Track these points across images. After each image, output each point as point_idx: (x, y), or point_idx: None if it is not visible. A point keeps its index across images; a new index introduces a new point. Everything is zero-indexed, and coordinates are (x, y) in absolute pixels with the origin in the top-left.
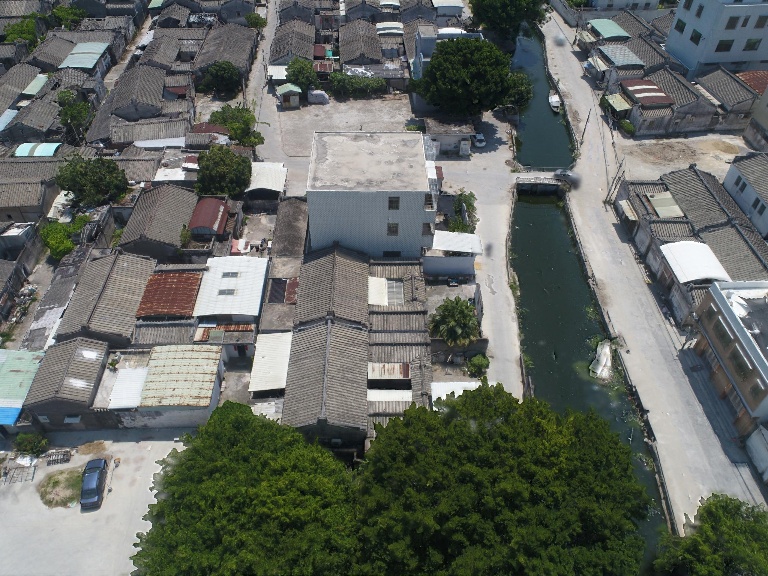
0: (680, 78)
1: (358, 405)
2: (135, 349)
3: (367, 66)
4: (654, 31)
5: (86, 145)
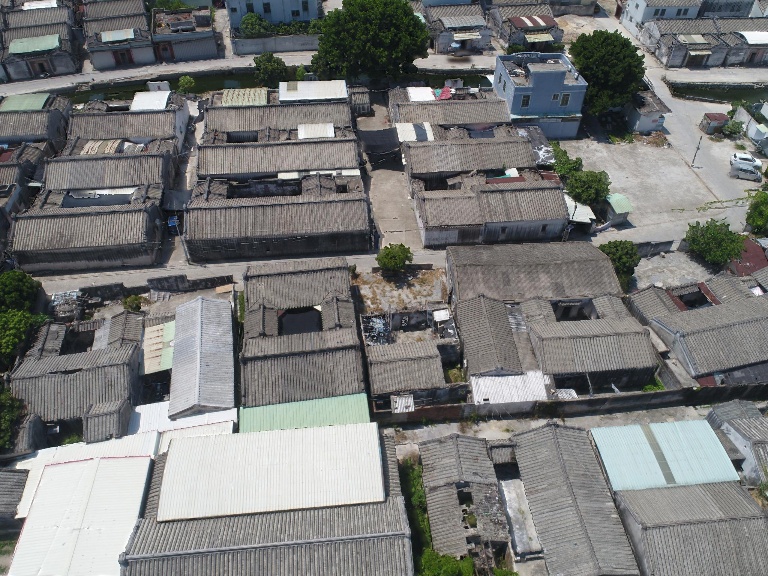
0: None
1: None
2: None
3: (532, 147)
4: None
5: None
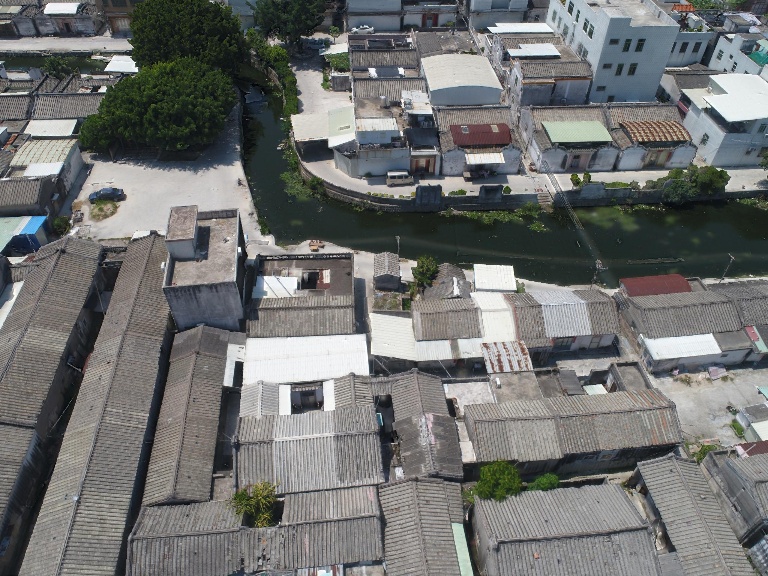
0: None
1: None
2: None
3: None
4: None
5: None
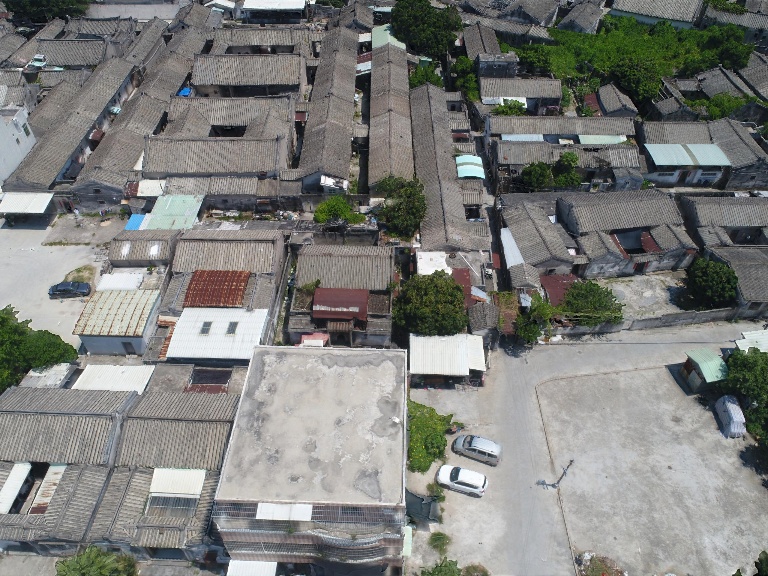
0: None
1: (2, 449)
2: None
3: None
4: None
5: (498, 197)
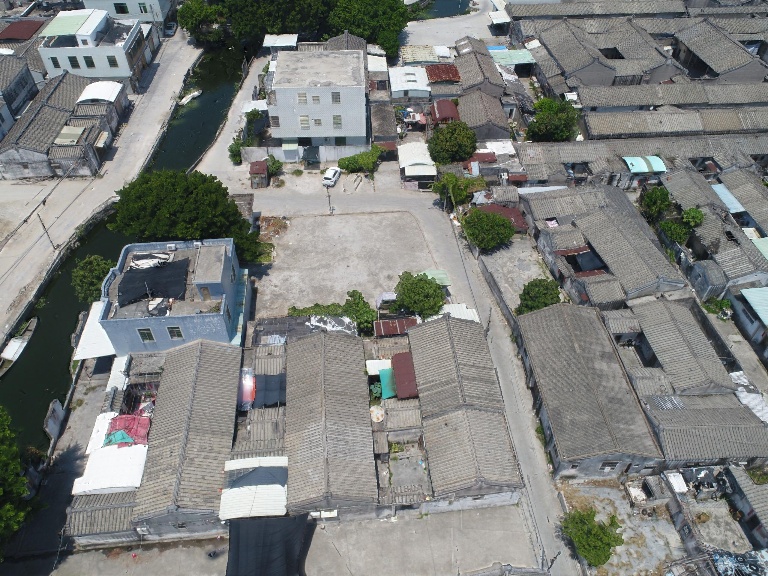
0: None
1: None
2: None
3: None
4: None
5: None
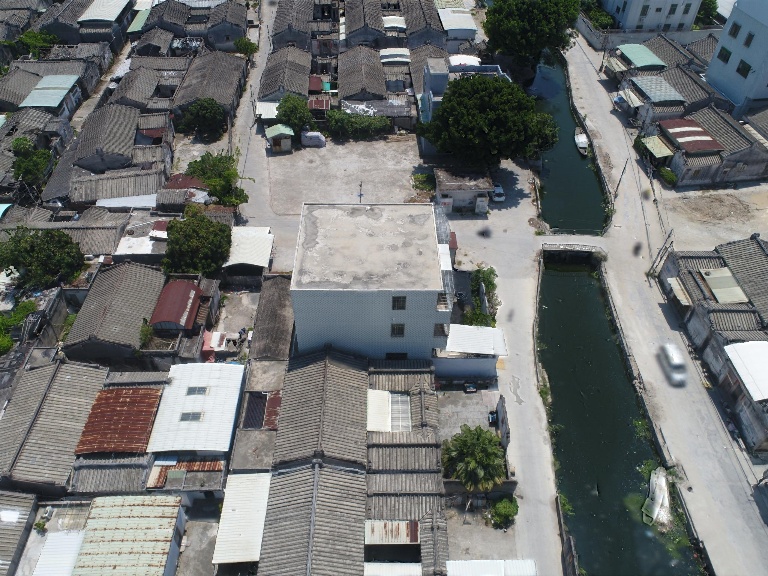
0: (727, 117)
1: None
2: (72, 500)
3: (369, 102)
4: (693, 60)
5: (42, 204)
